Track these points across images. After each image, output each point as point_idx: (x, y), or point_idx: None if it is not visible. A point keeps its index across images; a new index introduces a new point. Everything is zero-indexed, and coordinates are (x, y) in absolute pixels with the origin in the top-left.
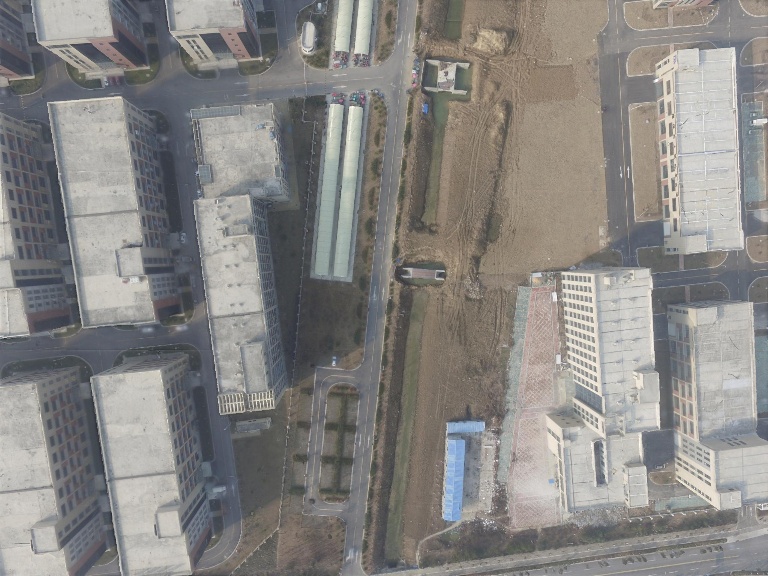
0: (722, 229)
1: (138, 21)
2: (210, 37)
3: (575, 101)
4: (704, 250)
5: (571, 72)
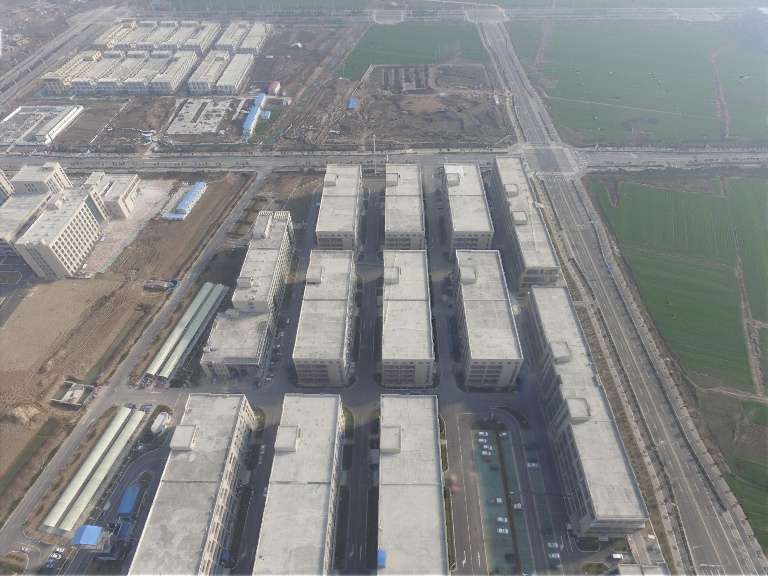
0: None
1: None
2: None
3: None
4: None
5: None
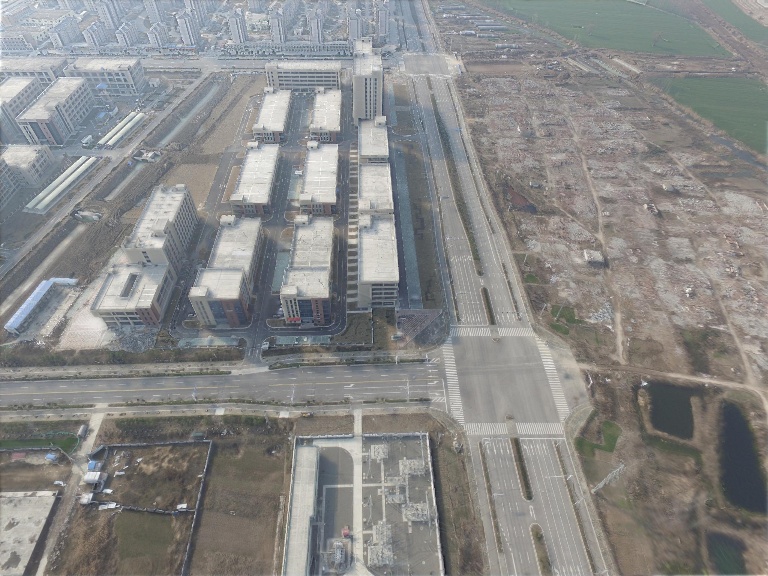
0: (258, 197)
1: (16, 133)
2: (34, 125)
3: (207, 164)
4: (241, 200)
5: (209, 156)
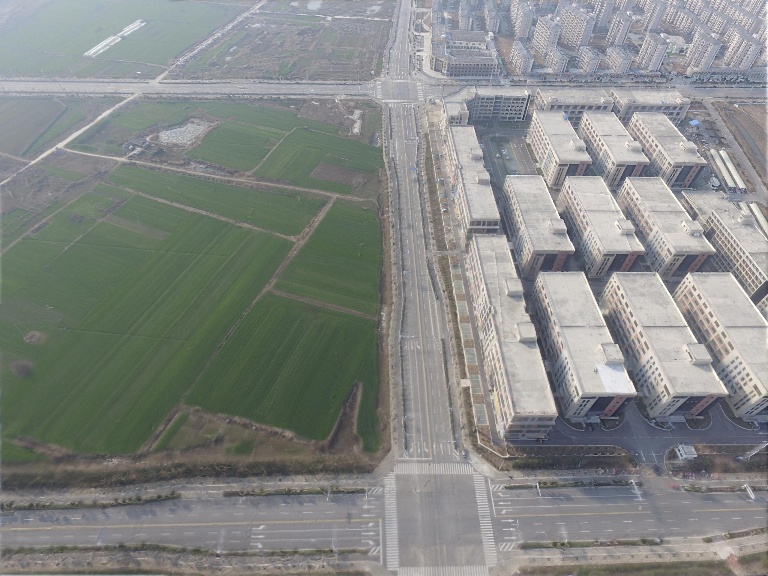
0: None
1: None
2: (686, 169)
3: None
4: None
5: None
